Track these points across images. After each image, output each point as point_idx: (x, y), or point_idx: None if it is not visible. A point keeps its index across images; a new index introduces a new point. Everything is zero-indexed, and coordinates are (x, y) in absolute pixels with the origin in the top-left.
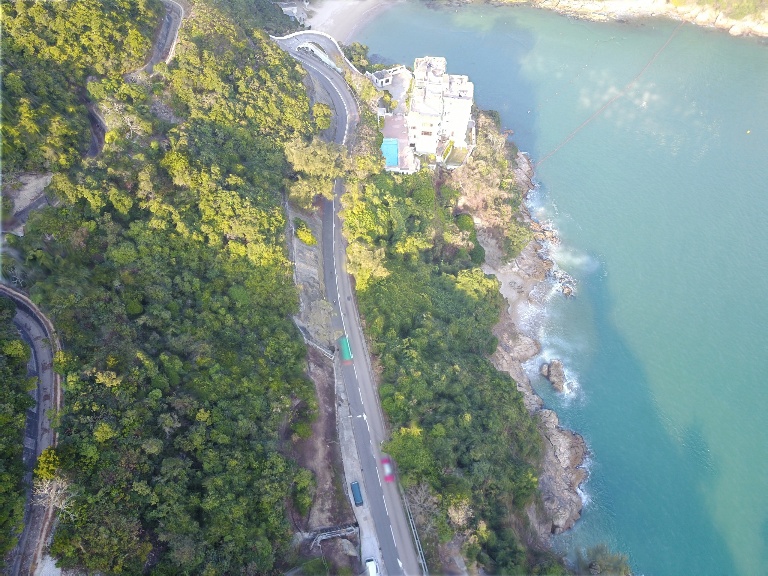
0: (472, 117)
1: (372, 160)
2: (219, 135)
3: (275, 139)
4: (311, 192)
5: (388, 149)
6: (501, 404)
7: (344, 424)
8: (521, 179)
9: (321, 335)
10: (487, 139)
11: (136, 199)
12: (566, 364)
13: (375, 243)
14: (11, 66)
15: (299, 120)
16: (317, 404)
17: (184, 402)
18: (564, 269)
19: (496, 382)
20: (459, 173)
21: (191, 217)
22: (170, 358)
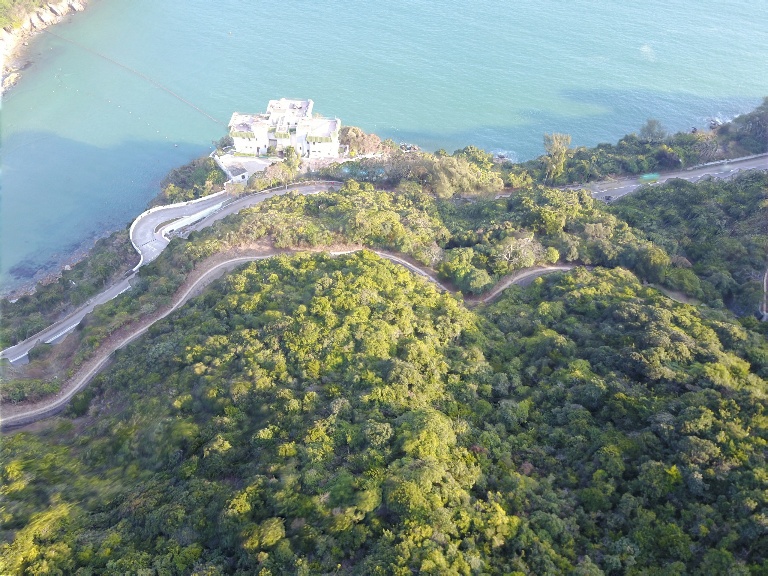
0: None
1: None
2: None
3: None
4: None
5: None
6: None
7: None
8: None
9: None
10: None
11: None
12: None
13: None
14: (506, 333)
15: None
16: None
17: None
18: None
19: None
20: (367, 143)
21: None
22: None
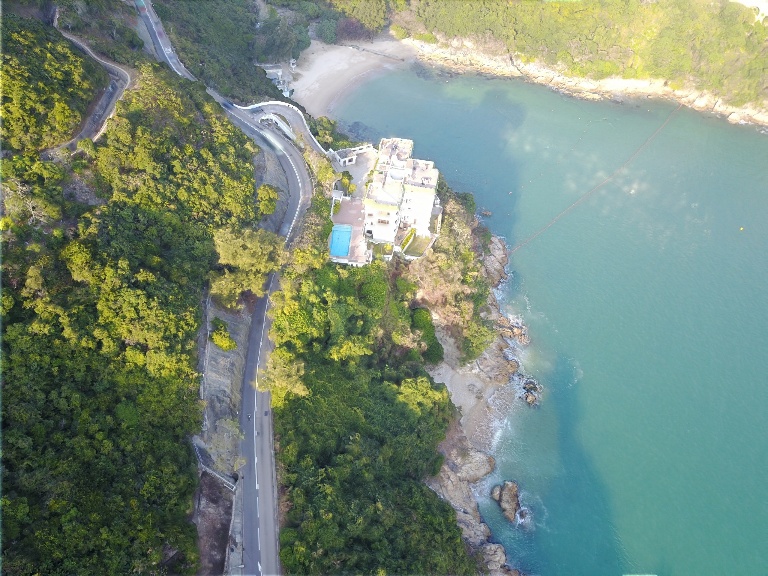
0: (441, 202)
1: (313, 254)
2: (141, 221)
3: (208, 225)
4: (237, 289)
5: (340, 236)
6: (430, 549)
7: (233, 575)
8: (493, 267)
9: (224, 460)
10: (452, 229)
11: (21, 297)
12: (521, 487)
13: (307, 347)
14: None
15: (239, 204)
16: (197, 556)
17: (13, 566)
18: (530, 372)
19: (428, 519)
20: (416, 266)
21: (85, 318)
22: (13, 503)
